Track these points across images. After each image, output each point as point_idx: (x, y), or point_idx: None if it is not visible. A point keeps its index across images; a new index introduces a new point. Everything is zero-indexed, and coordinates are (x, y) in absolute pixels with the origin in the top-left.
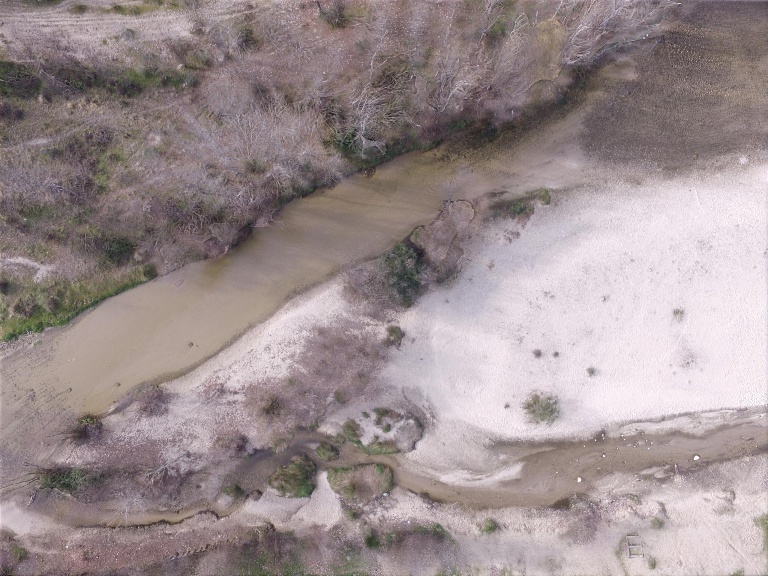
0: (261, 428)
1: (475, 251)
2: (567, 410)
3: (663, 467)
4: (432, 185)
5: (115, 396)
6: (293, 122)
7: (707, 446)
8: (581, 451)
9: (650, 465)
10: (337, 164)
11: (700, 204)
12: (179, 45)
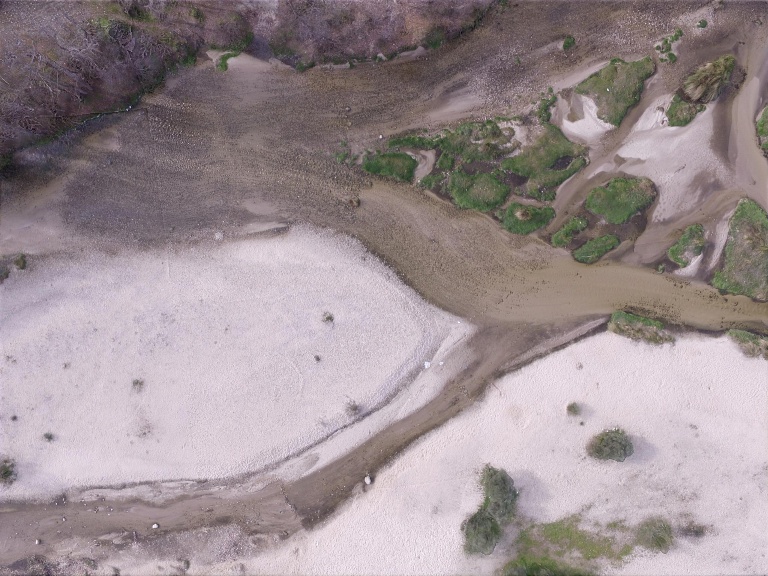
0: None
1: None
2: (25, 473)
3: (122, 533)
4: None
5: None
6: None
7: (166, 515)
8: (42, 514)
9: (109, 531)
10: None
11: (169, 277)
12: None
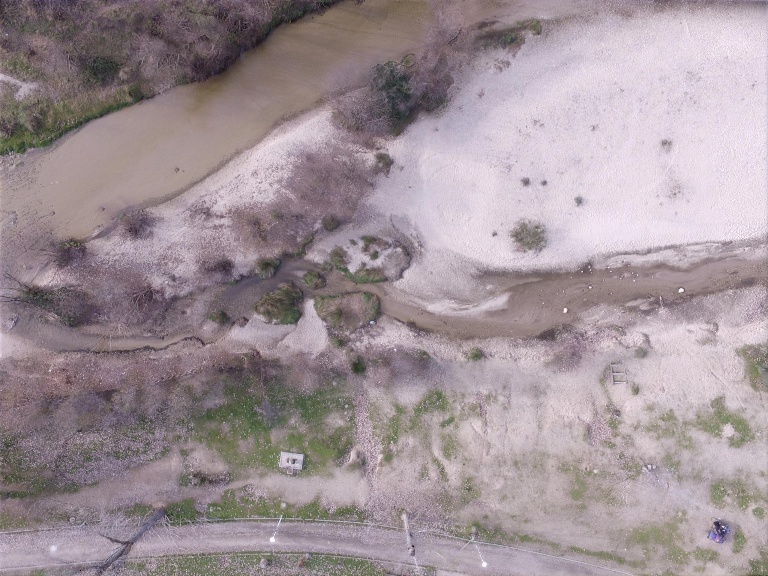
0: (248, 253)
1: (465, 80)
2: (554, 240)
3: (648, 299)
4: (423, 13)
5: (99, 220)
6: None
7: (692, 279)
8: (568, 282)
9: (635, 297)
10: None
11: (690, 36)
12: None
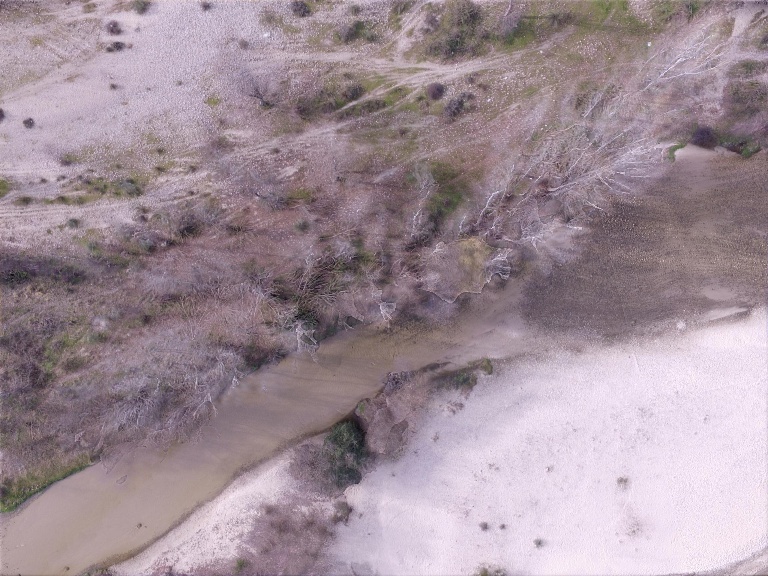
0: None
1: (419, 423)
2: None
3: None
4: (375, 358)
5: None
6: (236, 303)
7: None
8: None
9: None
10: (280, 343)
11: (639, 371)
12: (122, 233)
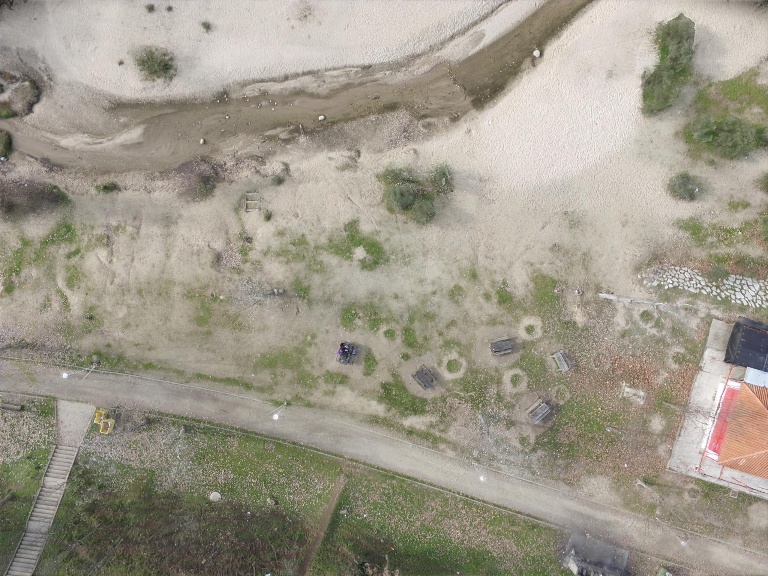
0: None
1: None
2: (185, 68)
3: (288, 128)
4: None
5: None
6: None
7: (332, 106)
8: (204, 113)
9: (275, 126)
10: None
11: None
12: None
